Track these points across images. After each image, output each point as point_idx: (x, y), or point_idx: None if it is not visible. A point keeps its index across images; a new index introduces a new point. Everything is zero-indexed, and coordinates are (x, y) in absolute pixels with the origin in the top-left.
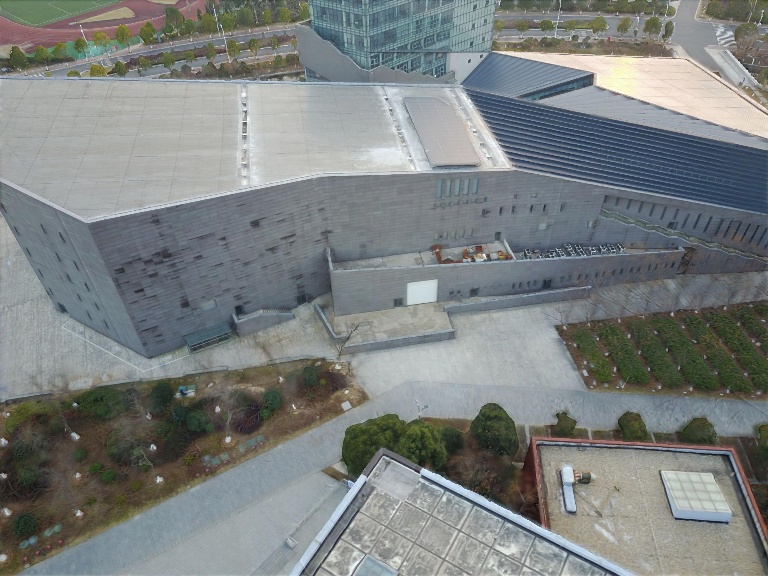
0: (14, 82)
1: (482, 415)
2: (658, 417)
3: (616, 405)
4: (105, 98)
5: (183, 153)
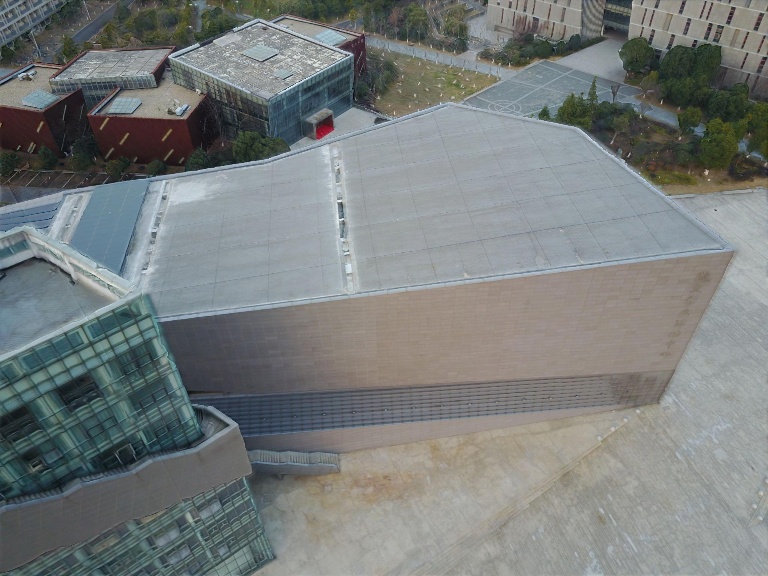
0: (686, 244)
1: None
2: None
3: None
4: (533, 231)
5: (399, 167)
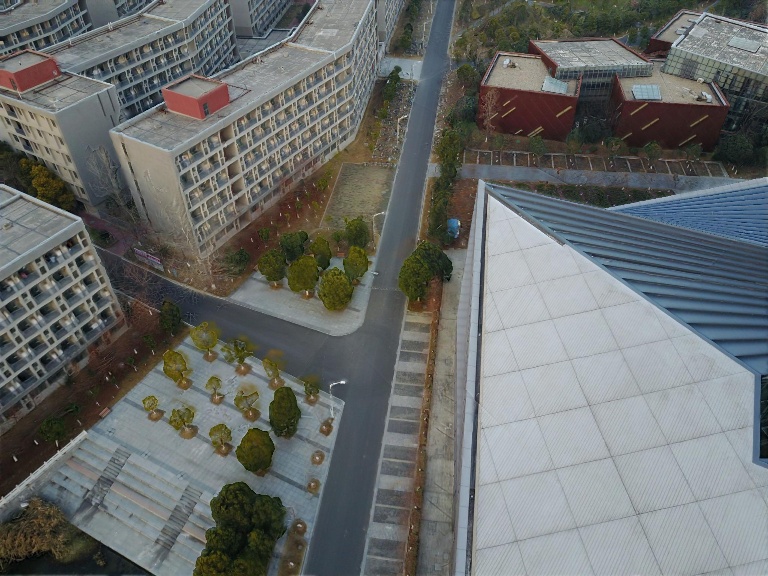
0: None
1: (752, 145)
2: (626, 178)
3: (653, 183)
4: None
5: None
